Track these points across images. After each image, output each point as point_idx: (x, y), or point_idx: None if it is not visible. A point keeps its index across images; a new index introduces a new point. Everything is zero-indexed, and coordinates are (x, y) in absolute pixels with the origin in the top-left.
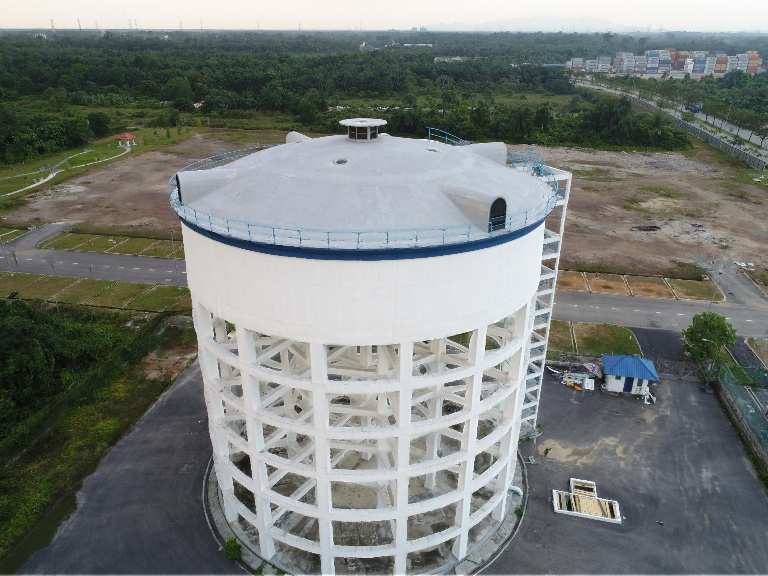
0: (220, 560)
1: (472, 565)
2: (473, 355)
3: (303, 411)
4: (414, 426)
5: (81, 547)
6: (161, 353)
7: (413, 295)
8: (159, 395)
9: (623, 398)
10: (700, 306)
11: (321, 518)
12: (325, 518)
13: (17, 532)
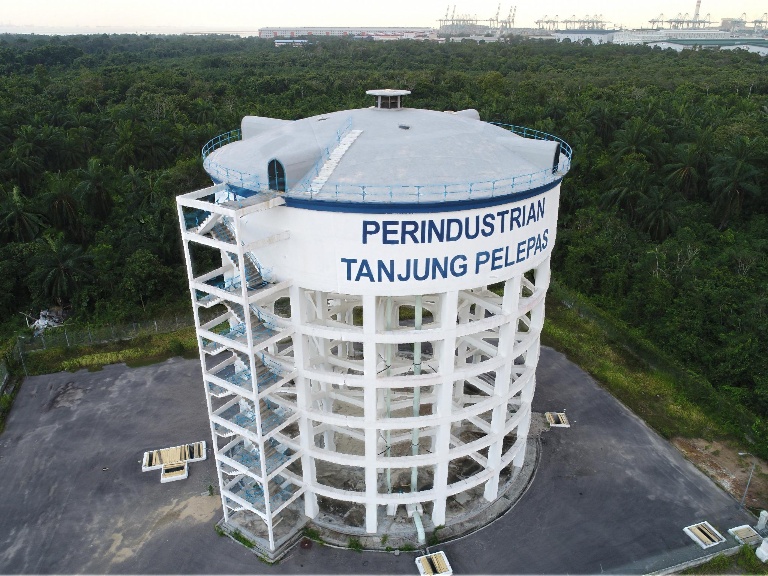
0: None
1: None
2: None
3: None
4: None
5: None
6: (762, 474)
7: None
8: None
9: None
10: None
11: None
12: None
13: None
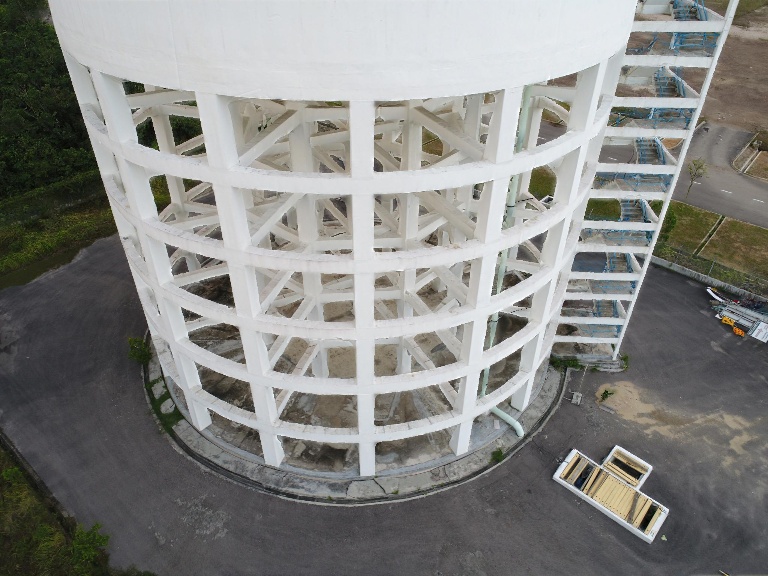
0: None
1: (377, 490)
2: None
3: None
4: (248, 252)
5: (43, 296)
6: None
7: None
8: None
9: None
10: None
11: (171, 345)
12: (174, 346)
13: (11, 264)
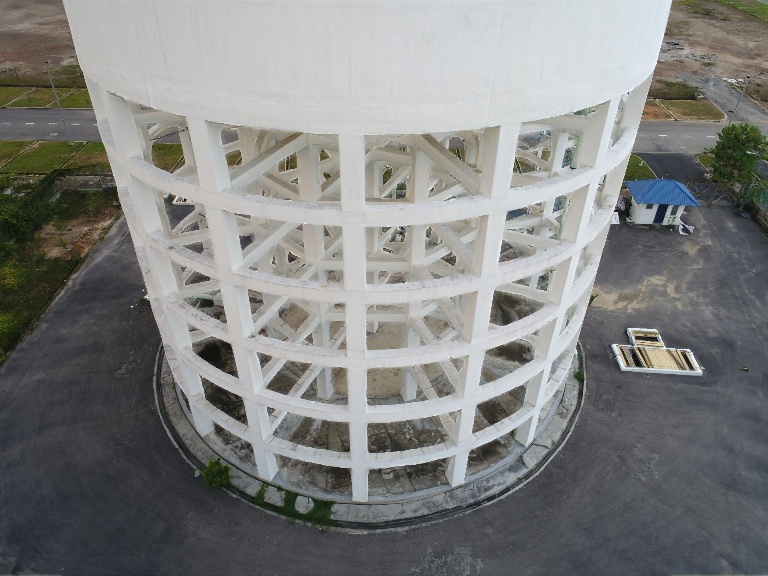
0: (200, 489)
1: (542, 450)
2: (593, 149)
3: (299, 271)
4: (502, 272)
5: None
6: (60, 224)
7: (532, 24)
8: (67, 277)
9: (655, 230)
10: (703, 126)
11: (353, 422)
12: (359, 421)
13: None
